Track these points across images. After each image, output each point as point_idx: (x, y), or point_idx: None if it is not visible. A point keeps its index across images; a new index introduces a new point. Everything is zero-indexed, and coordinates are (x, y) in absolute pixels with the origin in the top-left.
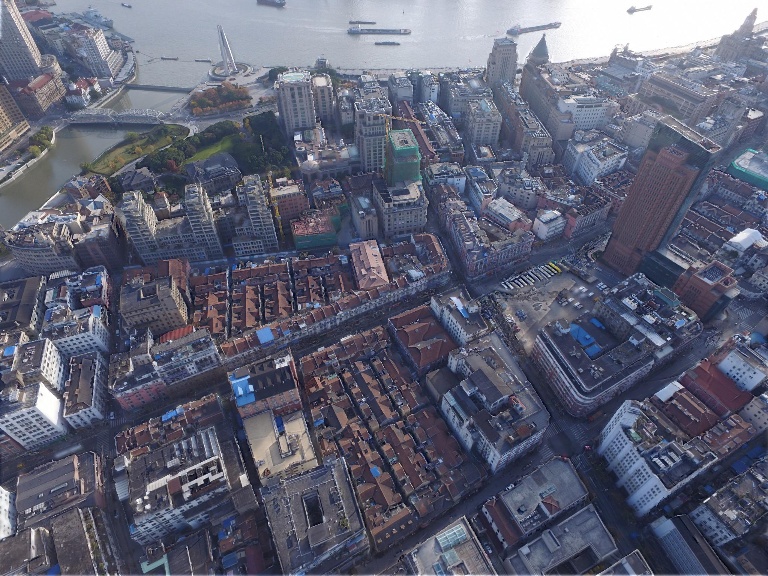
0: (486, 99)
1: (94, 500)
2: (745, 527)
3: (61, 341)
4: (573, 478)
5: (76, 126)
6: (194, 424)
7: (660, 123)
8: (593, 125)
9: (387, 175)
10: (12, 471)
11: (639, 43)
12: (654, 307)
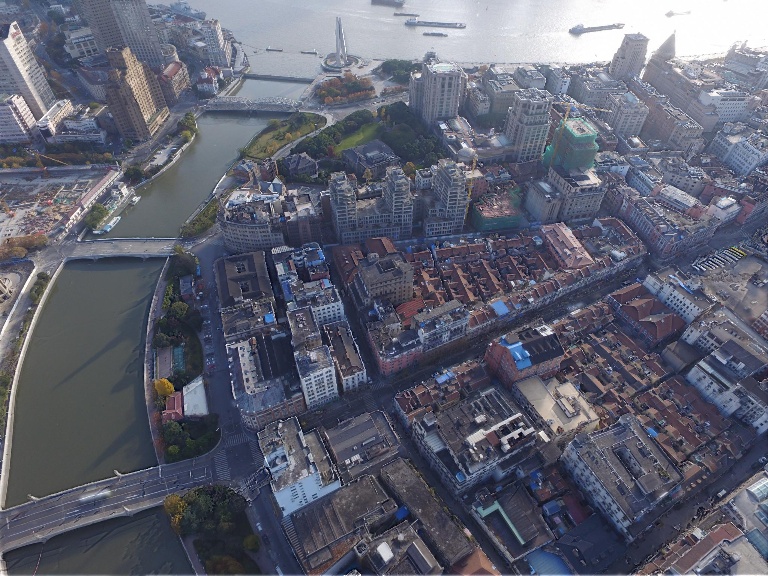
0: (622, 92)
1: (406, 453)
2: None
3: (315, 310)
4: None
5: (211, 113)
6: (464, 387)
7: None
8: (732, 118)
9: (553, 162)
10: None
11: (731, 42)
12: None
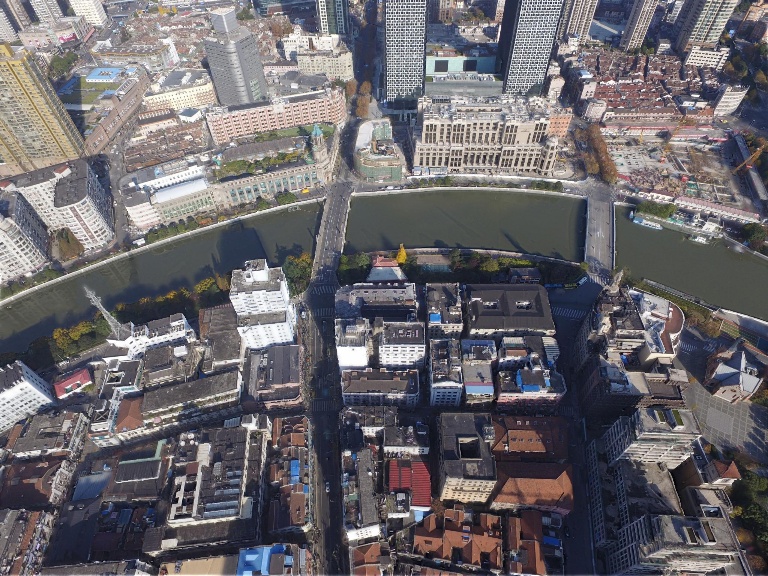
0: None
1: (245, 401)
2: None
3: None
4: None
5: None
6: None
7: None
8: None
9: None
10: (330, 340)
11: None
12: None
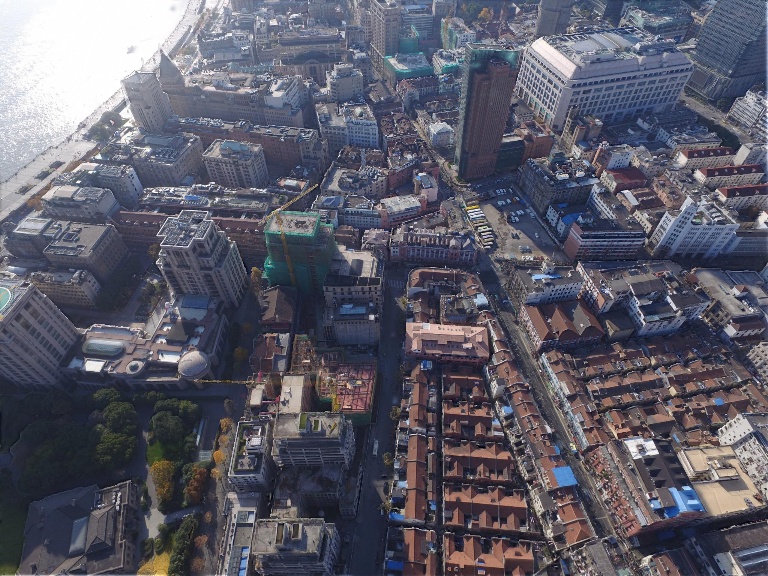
0: None
1: None
2: (734, 210)
3: None
4: (709, 272)
5: None
6: None
7: (474, 51)
8: (298, 104)
9: (294, 275)
10: None
11: (144, 30)
12: (567, 168)
